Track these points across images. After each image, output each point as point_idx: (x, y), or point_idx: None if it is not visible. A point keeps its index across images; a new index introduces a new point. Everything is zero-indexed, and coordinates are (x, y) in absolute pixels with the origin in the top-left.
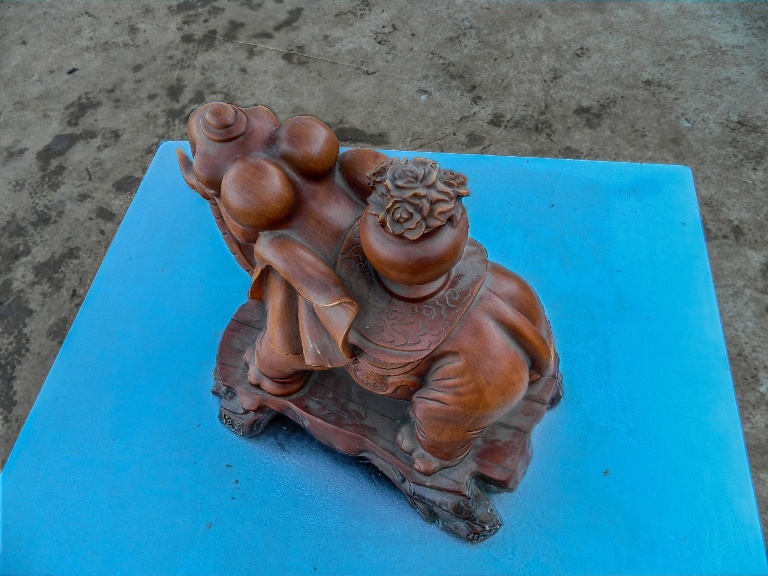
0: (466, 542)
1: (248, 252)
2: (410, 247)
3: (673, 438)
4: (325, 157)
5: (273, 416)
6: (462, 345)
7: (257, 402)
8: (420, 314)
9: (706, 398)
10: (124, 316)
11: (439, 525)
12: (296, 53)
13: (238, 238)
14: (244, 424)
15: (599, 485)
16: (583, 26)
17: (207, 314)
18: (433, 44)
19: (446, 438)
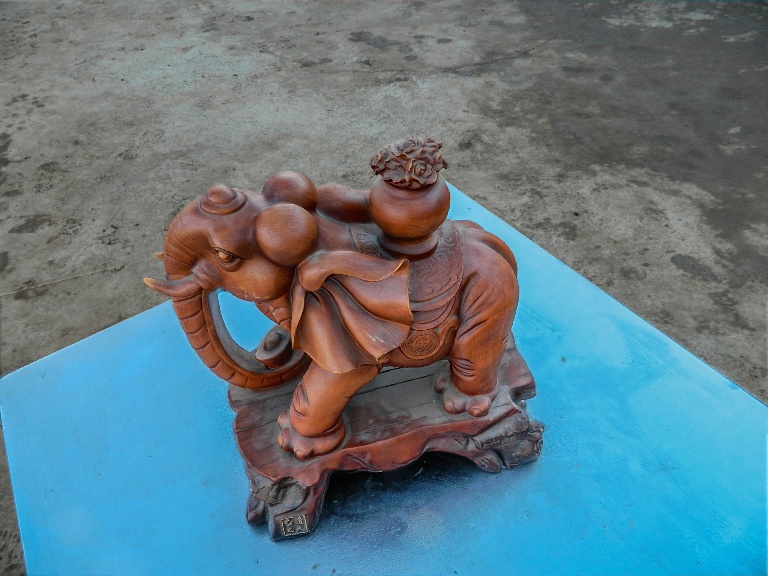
0: (532, 463)
1: (230, 354)
2: (428, 196)
3: (576, 316)
4: (314, 190)
5: (328, 487)
6: (475, 265)
7: (317, 471)
8: (438, 262)
9: (570, 286)
10: (91, 539)
11: (507, 466)
12: (28, 288)
13: (268, 295)
14: (307, 514)
15: (567, 369)
16: (271, 162)
17: (182, 475)
18: (161, 223)
19: (491, 359)
